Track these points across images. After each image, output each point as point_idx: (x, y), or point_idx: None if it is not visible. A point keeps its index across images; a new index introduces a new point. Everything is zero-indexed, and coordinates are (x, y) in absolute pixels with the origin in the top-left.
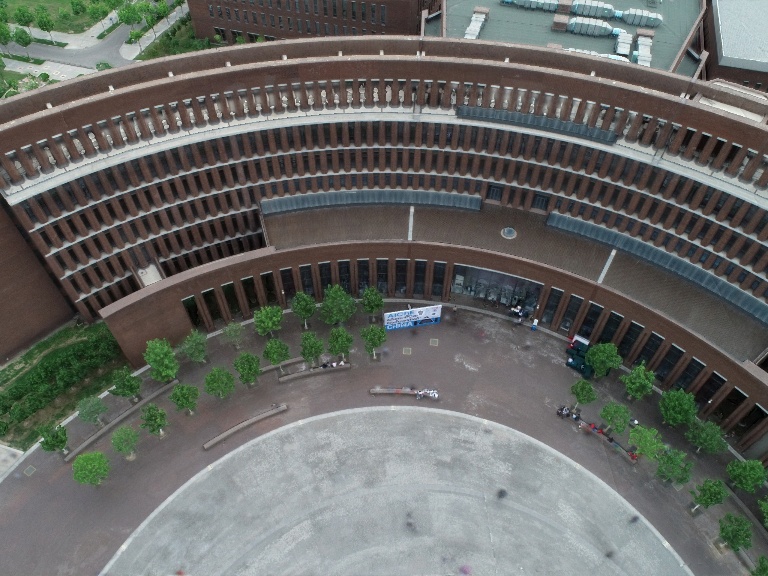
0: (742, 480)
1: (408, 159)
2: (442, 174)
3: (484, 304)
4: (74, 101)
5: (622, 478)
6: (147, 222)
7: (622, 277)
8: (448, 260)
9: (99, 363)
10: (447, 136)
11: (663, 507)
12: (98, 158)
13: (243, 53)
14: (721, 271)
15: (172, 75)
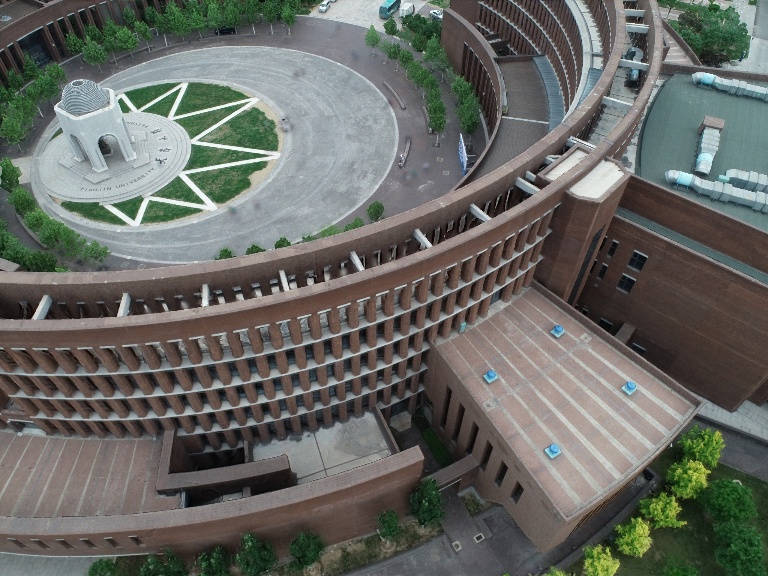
0: None
1: None
2: None
3: None
4: None
5: None
6: None
7: None
8: None
9: None
10: None
11: None
12: None
13: None
14: None
15: None
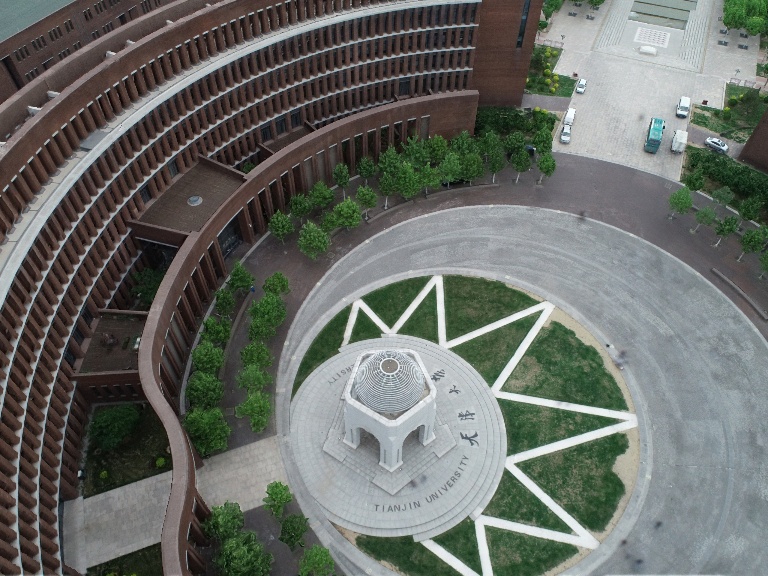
0: None
1: None
2: None
3: None
4: None
5: None
6: None
7: None
8: None
9: (760, 199)
10: None
11: None
12: None
13: None
14: None
15: None
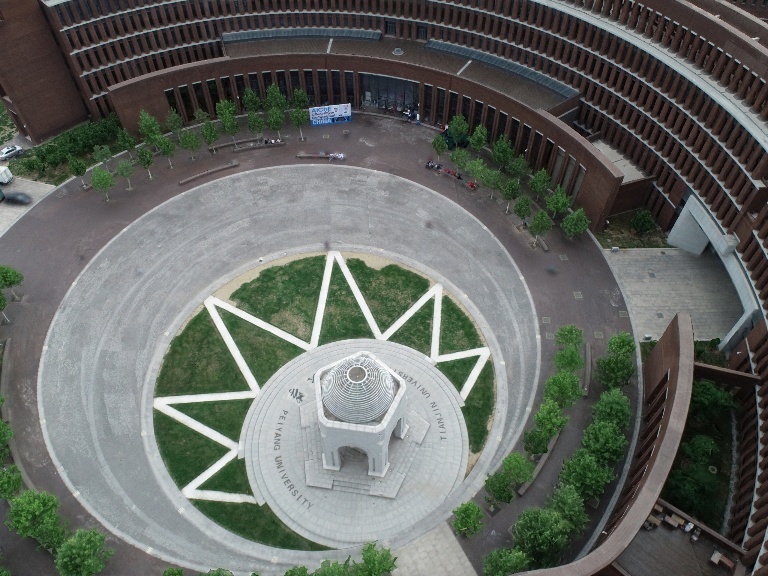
0: (534, 184)
1: (326, 0)
2: (352, 13)
3: (385, 112)
4: None
5: (463, 198)
6: (140, 42)
7: (472, 74)
8: (354, 69)
9: (107, 136)
10: None
11: (487, 211)
12: None
13: None
14: (537, 66)
15: None
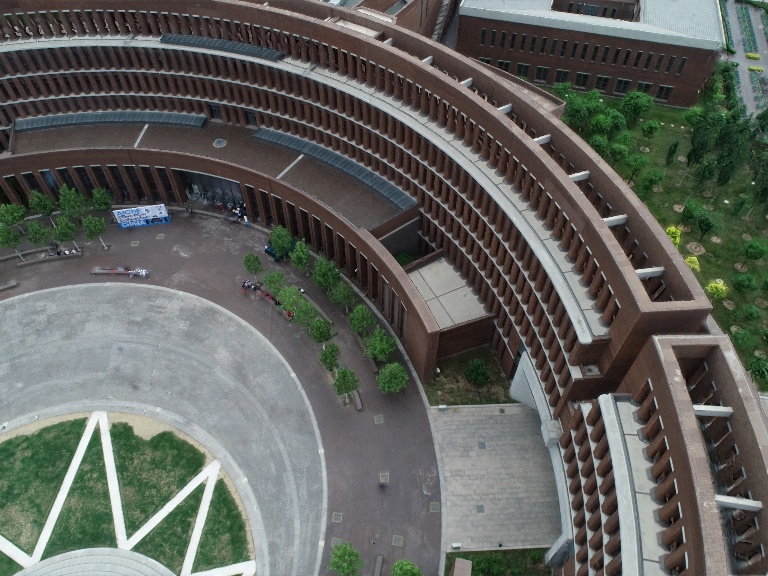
0: None
1: (135, 82)
2: (167, 95)
3: (214, 208)
4: None
5: (277, 331)
6: None
7: (299, 174)
8: (165, 165)
9: None
10: (158, 60)
11: (302, 350)
12: None
13: None
14: (373, 166)
15: None
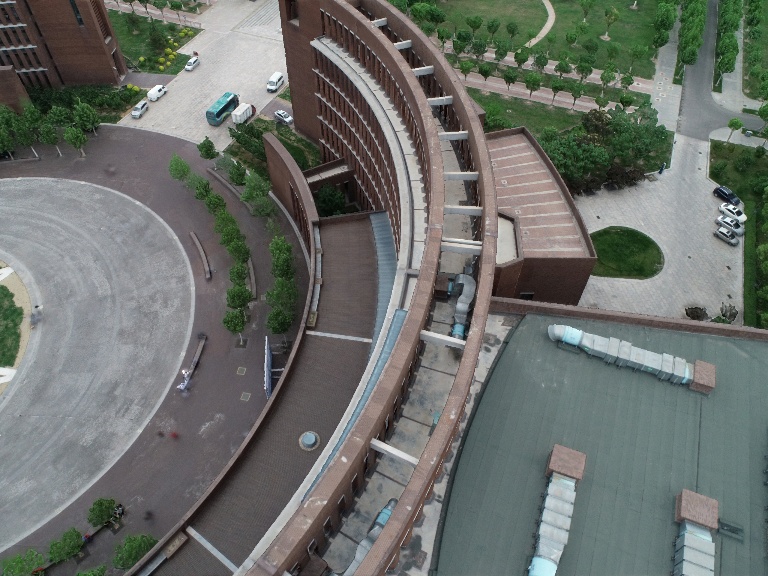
0: None
1: None
2: None
3: None
4: (370, 21)
5: None
6: None
7: (198, 574)
8: None
9: None
10: None
11: None
12: (358, 69)
13: (458, 99)
14: None
15: (427, 67)
